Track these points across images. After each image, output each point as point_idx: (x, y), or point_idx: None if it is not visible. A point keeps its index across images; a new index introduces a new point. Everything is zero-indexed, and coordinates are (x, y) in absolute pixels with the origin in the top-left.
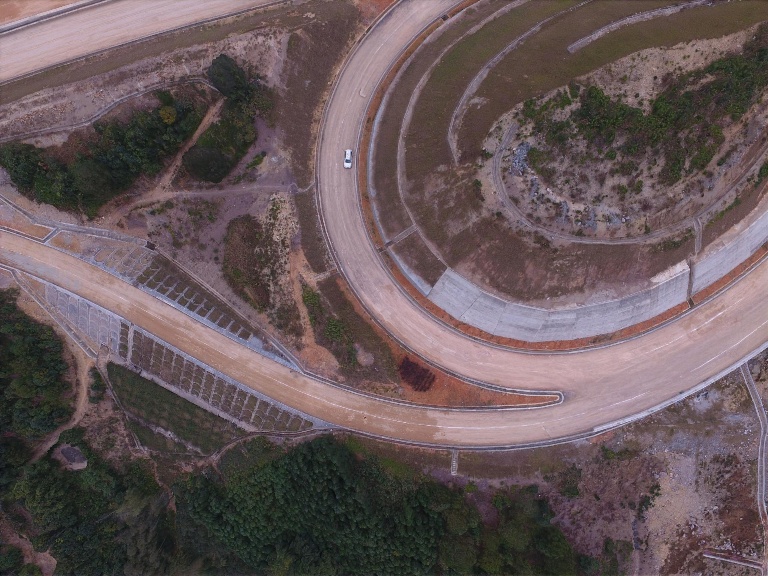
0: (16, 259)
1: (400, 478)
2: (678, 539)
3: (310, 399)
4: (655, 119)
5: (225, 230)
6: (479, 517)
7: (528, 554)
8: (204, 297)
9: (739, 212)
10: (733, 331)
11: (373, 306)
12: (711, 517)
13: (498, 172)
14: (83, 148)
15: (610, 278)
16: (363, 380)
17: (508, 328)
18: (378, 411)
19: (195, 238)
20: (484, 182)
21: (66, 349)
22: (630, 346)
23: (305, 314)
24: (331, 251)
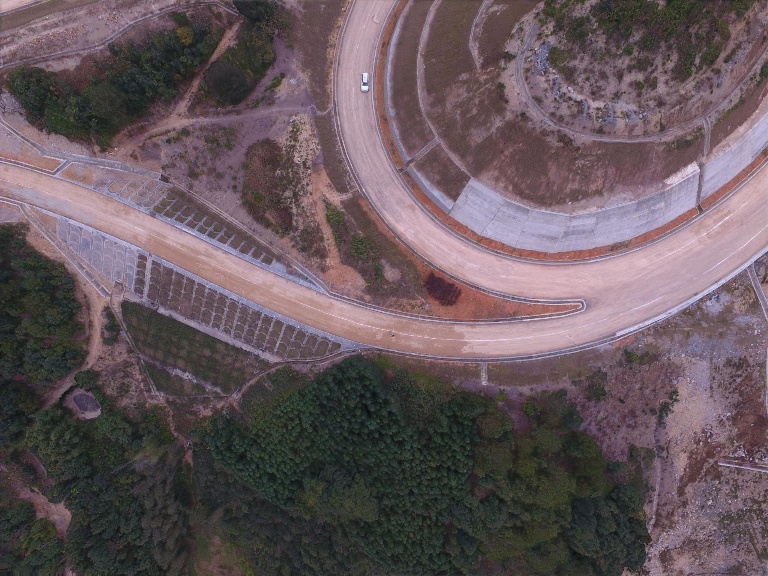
0: (24, 193)
1: (432, 390)
2: (696, 447)
3: (337, 320)
4: (669, 11)
5: (243, 156)
6: (512, 422)
7: (559, 462)
8: (223, 226)
9: (743, 113)
10: (740, 234)
11: (396, 225)
12: (725, 424)
13: (520, 74)
14: (97, 71)
15: (627, 181)
16: (390, 298)
17: (530, 239)
18: (406, 328)
19: (212, 167)
20: (507, 84)
21: (78, 288)
22: (645, 253)
23: (329, 235)
24: (352, 173)
